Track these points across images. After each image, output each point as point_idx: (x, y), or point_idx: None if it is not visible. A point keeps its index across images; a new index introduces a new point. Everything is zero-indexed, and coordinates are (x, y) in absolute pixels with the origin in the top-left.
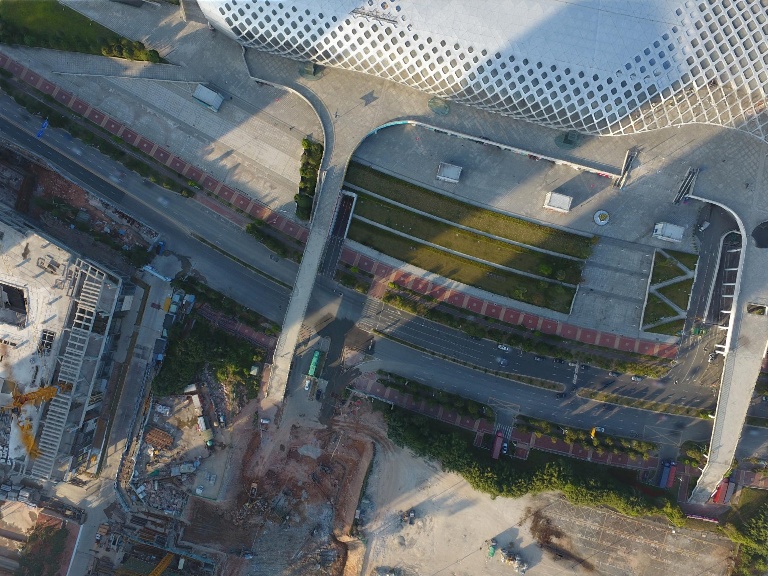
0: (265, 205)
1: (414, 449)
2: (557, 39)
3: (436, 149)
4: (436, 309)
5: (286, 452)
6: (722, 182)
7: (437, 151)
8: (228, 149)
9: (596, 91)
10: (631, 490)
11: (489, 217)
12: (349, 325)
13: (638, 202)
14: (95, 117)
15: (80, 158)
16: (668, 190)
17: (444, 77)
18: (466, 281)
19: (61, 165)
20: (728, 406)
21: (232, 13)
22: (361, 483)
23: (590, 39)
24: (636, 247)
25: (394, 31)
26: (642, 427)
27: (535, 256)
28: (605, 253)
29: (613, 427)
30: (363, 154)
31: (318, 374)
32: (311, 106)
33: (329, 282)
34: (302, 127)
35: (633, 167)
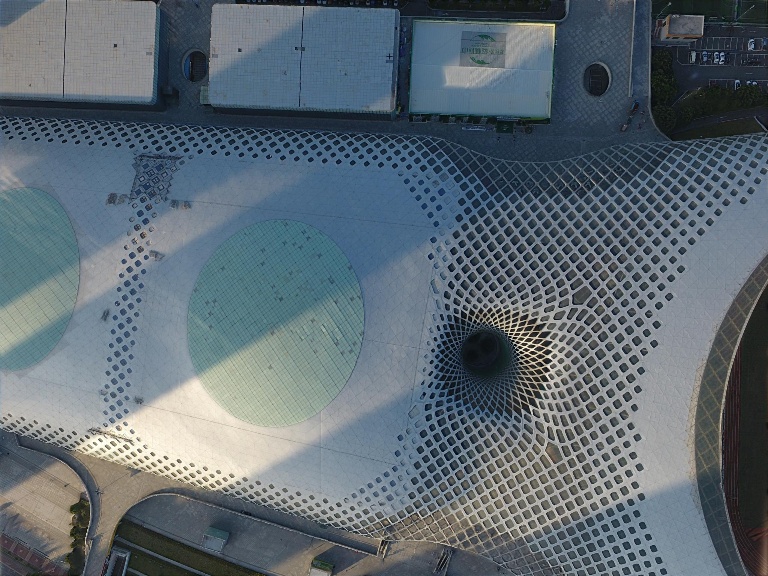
0: (43, 555)
1: None
2: (284, 469)
3: (206, 510)
4: None
5: None
6: (475, 564)
7: (207, 512)
8: (6, 501)
9: (328, 510)
10: None
11: None
12: None
13: (401, 569)
14: None
15: None
16: (428, 562)
17: (188, 482)
18: None
19: None
20: None
21: None
22: None
23: (315, 471)
24: None
25: (132, 447)
26: None
27: None
28: None
29: None
30: (136, 513)
31: None
32: (78, 475)
33: None
34: (77, 484)
35: (392, 542)
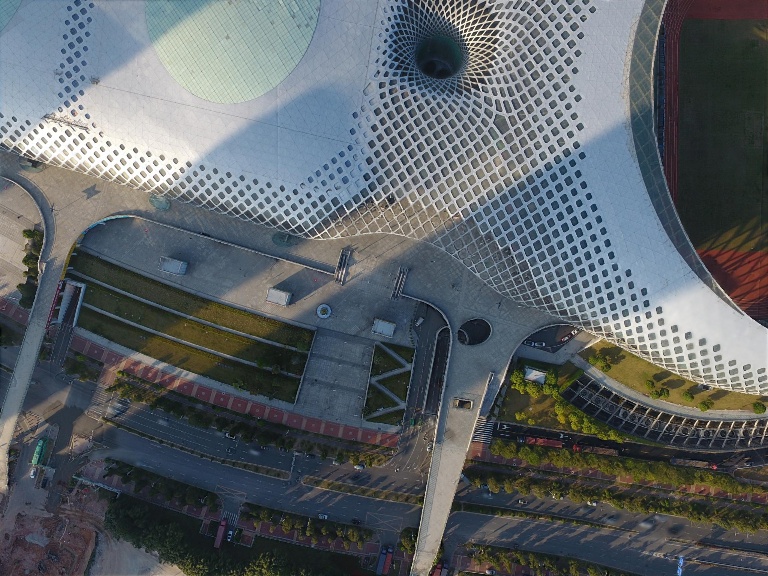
0: None
1: (130, 541)
2: (241, 152)
3: (164, 241)
4: (165, 397)
5: (11, 541)
6: (431, 282)
7: (165, 243)
8: None
9: (285, 200)
10: None
11: (216, 309)
12: (78, 413)
13: (359, 297)
14: None
15: None
16: (385, 286)
17: (144, 180)
18: (195, 370)
19: None
20: (435, 497)
21: None
22: (83, 573)
23: (272, 153)
24: (357, 340)
25: (87, 137)
26: (364, 514)
27: (261, 347)
28: (328, 345)
29: (336, 514)
30: (92, 244)
31: (45, 462)
32: (32, 198)
33: (59, 369)
34: (30, 216)
35: (350, 265)
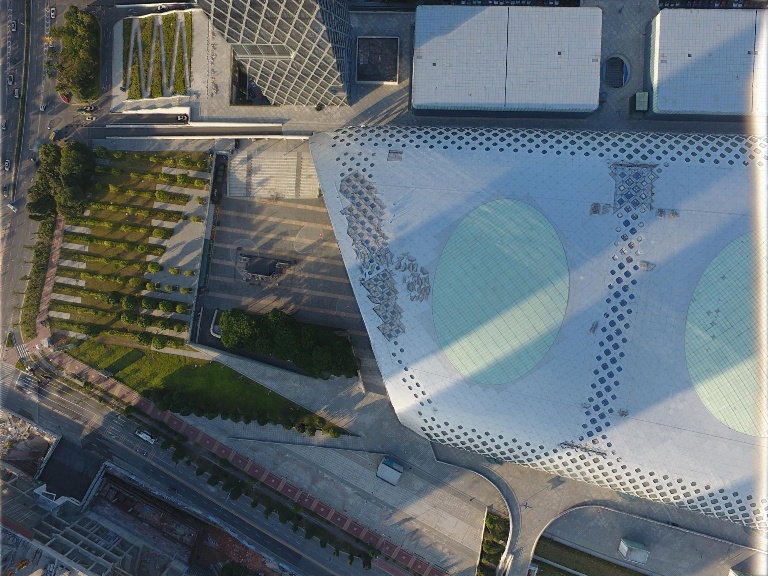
0: (443, 570)
1: None
2: None
3: (618, 522)
4: None
5: None
6: None
7: (619, 524)
8: (407, 516)
9: None
10: None
11: None
12: None
13: None
14: (272, 481)
15: (256, 521)
16: None
17: (647, 494)
18: None
19: (237, 527)
20: None
21: (434, 432)
22: None
23: None
24: None
25: (602, 461)
26: None
27: None
28: None
29: None
30: None
31: None
32: (497, 489)
33: None
34: (482, 498)
35: None
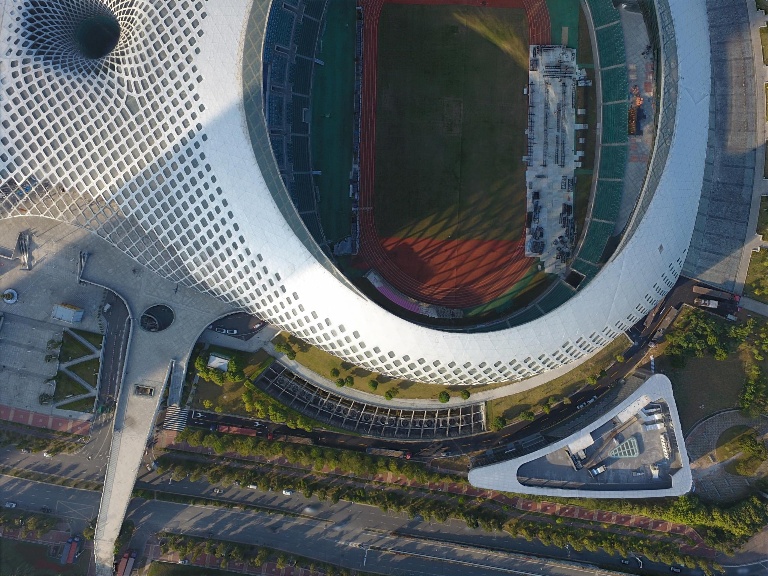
0: None
1: None
2: None
3: None
4: None
5: None
6: (112, 267)
7: None
8: None
9: None
10: (16, 568)
11: None
12: None
13: (47, 282)
14: None
15: None
16: (71, 272)
17: None
18: None
19: None
20: (114, 485)
21: None
22: None
23: None
24: (46, 326)
25: None
26: (54, 502)
27: None
28: (17, 331)
29: (26, 502)
30: None
31: None
32: None
33: None
34: None
35: (31, 249)
